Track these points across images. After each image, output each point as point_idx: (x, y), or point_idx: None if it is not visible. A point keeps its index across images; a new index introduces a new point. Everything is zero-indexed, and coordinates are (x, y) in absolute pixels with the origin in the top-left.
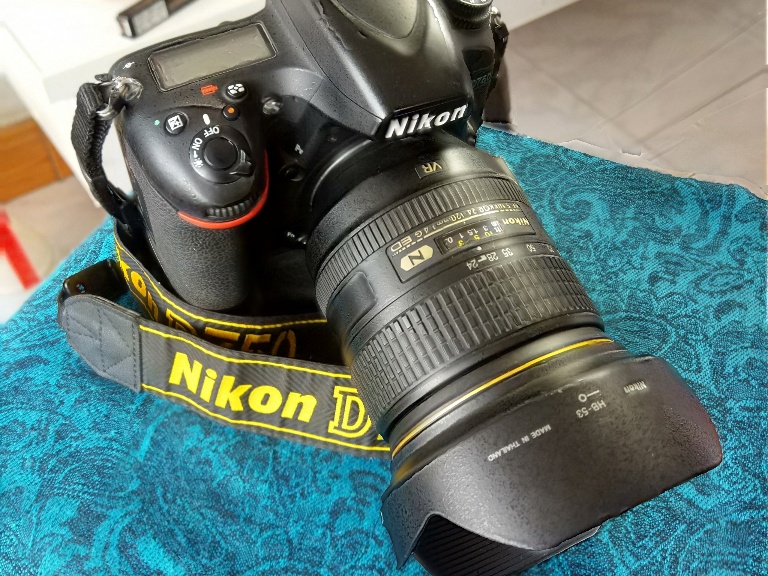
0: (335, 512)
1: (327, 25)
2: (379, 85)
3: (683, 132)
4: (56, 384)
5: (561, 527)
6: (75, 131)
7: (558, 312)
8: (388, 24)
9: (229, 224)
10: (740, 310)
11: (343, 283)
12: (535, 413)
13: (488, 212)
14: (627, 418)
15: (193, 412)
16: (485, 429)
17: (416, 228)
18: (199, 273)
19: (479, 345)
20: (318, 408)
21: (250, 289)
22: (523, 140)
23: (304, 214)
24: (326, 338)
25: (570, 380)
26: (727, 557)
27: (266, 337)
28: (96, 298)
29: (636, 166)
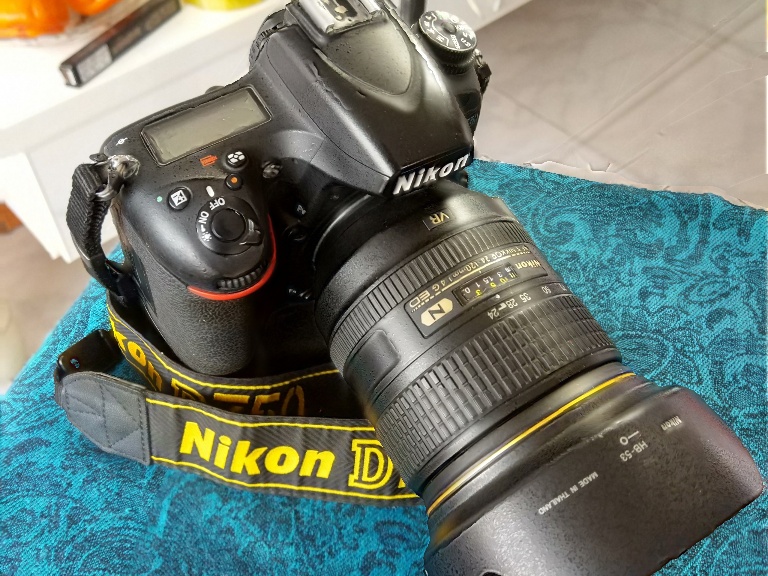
0: (366, 567)
1: (324, 87)
2: (383, 143)
3: (647, 142)
4: (61, 466)
5: (623, 575)
6: (71, 213)
7: (582, 353)
8: (385, 81)
9: (241, 294)
10: (730, 317)
11: (362, 342)
12: (580, 461)
13: (501, 258)
14: (670, 456)
15: (207, 480)
16: (531, 482)
17: (432, 281)
18: (208, 342)
19: (511, 395)
20: (336, 463)
21: (255, 349)
22: (498, 166)
23: (306, 270)
24: (334, 389)
25: (608, 423)
26: (754, 567)
27: (275, 396)
28: (97, 375)
29: (611, 183)
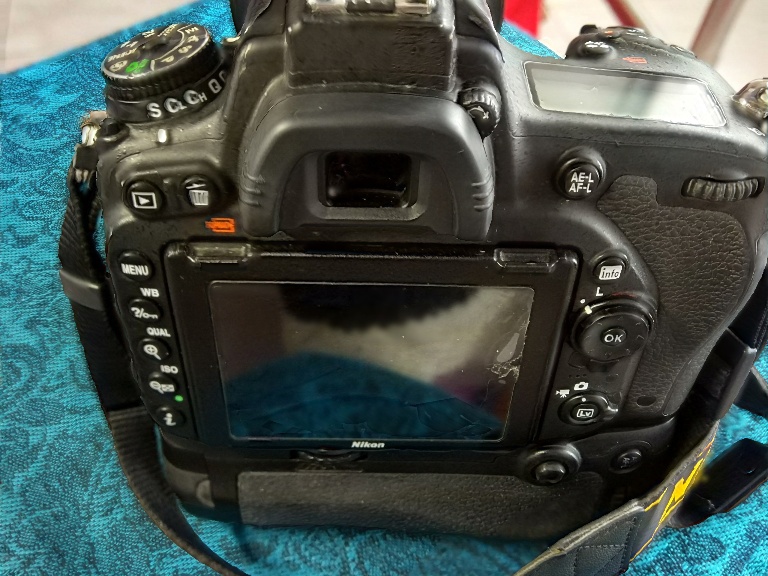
0: None
1: None
2: None
3: None
4: None
5: None
6: None
7: None
8: None
9: None
10: None
11: None
12: None
13: None
14: None
15: None
16: None
17: None
18: None
19: None
20: None
21: None
22: None
23: None
24: None
25: None
26: None
27: None
28: None
29: None
